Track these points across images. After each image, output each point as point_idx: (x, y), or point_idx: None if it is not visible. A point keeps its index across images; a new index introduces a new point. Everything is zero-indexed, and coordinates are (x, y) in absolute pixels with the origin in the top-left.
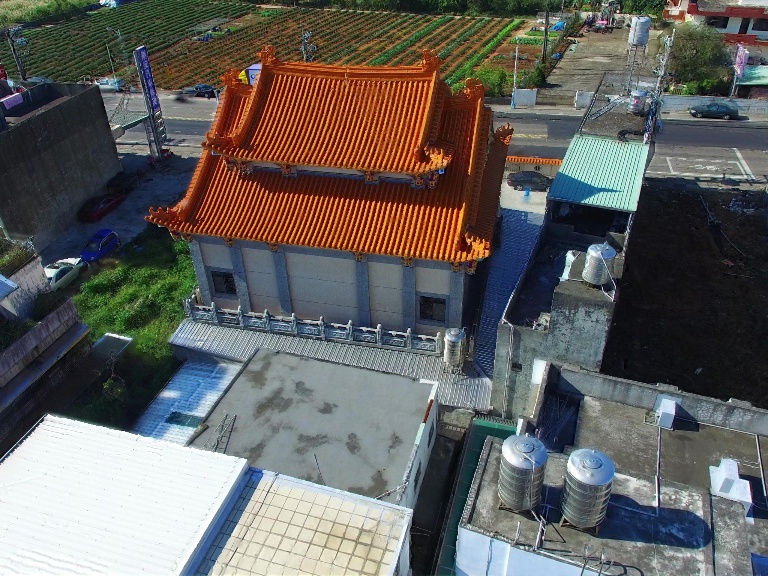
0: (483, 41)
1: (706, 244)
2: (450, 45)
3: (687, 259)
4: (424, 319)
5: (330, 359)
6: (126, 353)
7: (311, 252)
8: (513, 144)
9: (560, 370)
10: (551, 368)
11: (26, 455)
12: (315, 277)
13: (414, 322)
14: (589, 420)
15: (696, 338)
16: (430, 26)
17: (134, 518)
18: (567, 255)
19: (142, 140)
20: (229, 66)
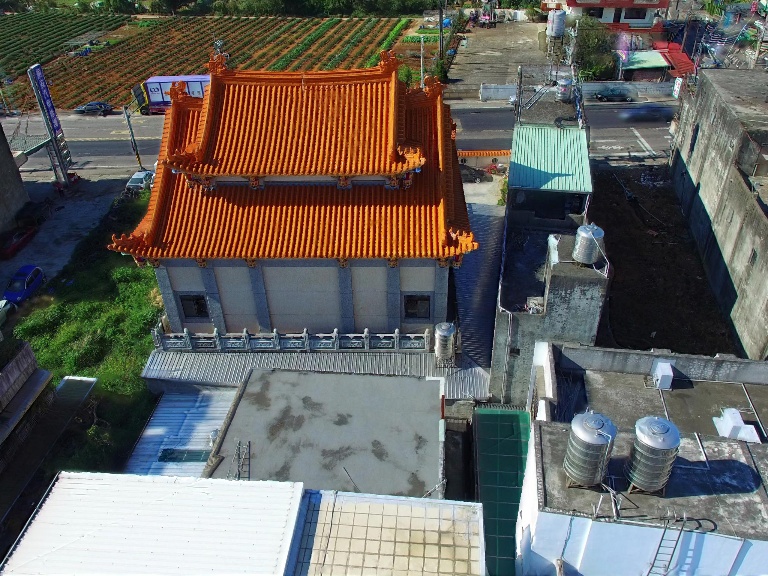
0: (376, 41)
1: (630, 218)
2: (345, 47)
3: (617, 233)
4: (409, 318)
5: (320, 370)
6: None
7: (290, 264)
8: None
9: (561, 349)
10: (553, 348)
11: (52, 519)
12: (295, 289)
13: (399, 322)
14: (597, 392)
15: (643, 305)
16: (320, 29)
17: (202, 564)
18: (550, 239)
19: (40, 166)
20: (118, 81)
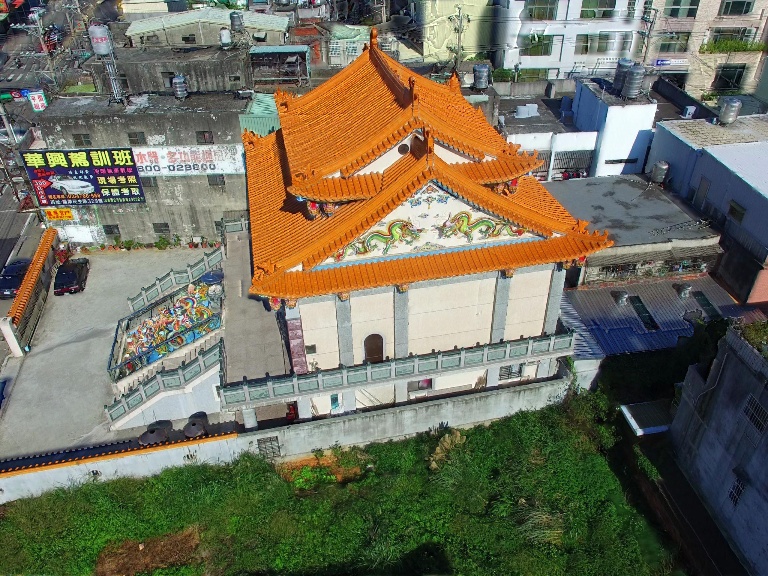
0: None
1: None
2: None
3: None
4: None
5: None
6: None
7: None
8: None
9: None
10: None
11: None
12: None
13: None
14: None
15: None
16: None
17: (767, 160)
18: None
19: None
20: None
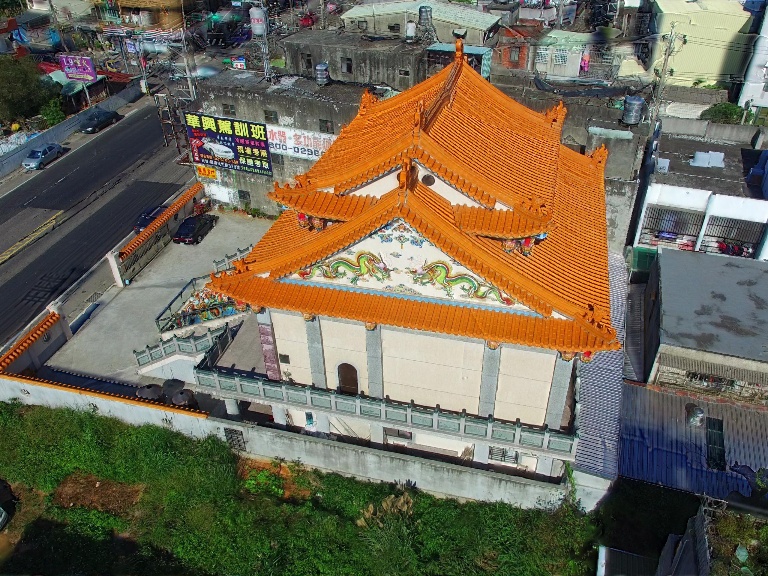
0: None
1: None
2: None
3: None
4: None
5: None
6: None
7: None
8: (65, 235)
9: None
10: None
11: None
12: None
13: None
14: None
15: None
16: None
17: None
18: (594, 130)
19: None
20: None
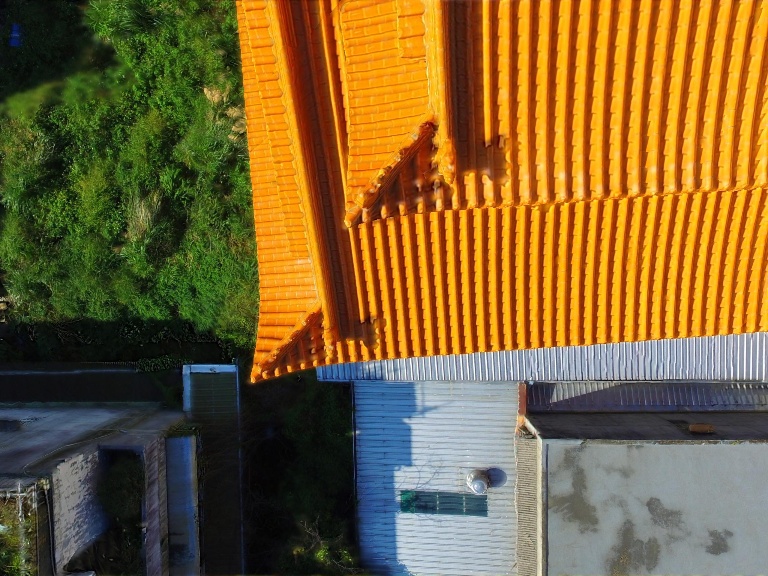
0: None
1: None
2: None
3: None
4: None
5: None
6: (241, 388)
7: None
8: None
9: None
10: None
11: None
12: None
13: None
14: None
15: None
16: None
17: None
18: None
19: None
20: None
